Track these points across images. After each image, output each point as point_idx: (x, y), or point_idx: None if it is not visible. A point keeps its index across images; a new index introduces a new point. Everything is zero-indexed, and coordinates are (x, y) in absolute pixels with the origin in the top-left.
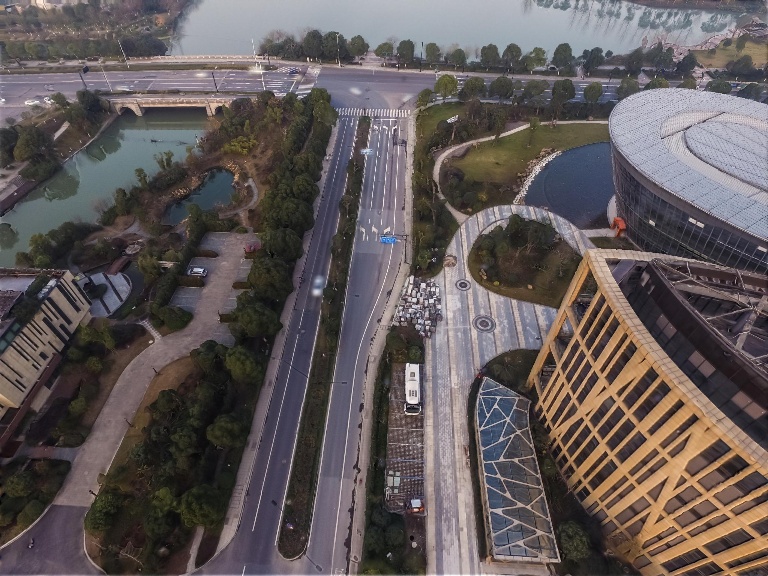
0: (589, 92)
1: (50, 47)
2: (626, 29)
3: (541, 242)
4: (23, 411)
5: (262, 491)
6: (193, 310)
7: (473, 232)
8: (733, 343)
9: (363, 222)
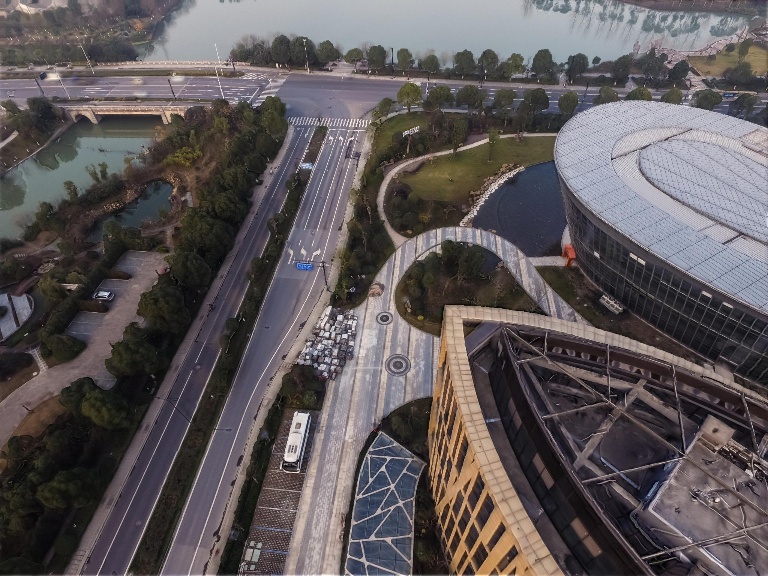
0: (563, 102)
1: (17, 52)
2: (629, 33)
3: (473, 273)
4: None
5: (105, 559)
6: (89, 339)
7: (408, 257)
8: (579, 449)
9: (293, 243)
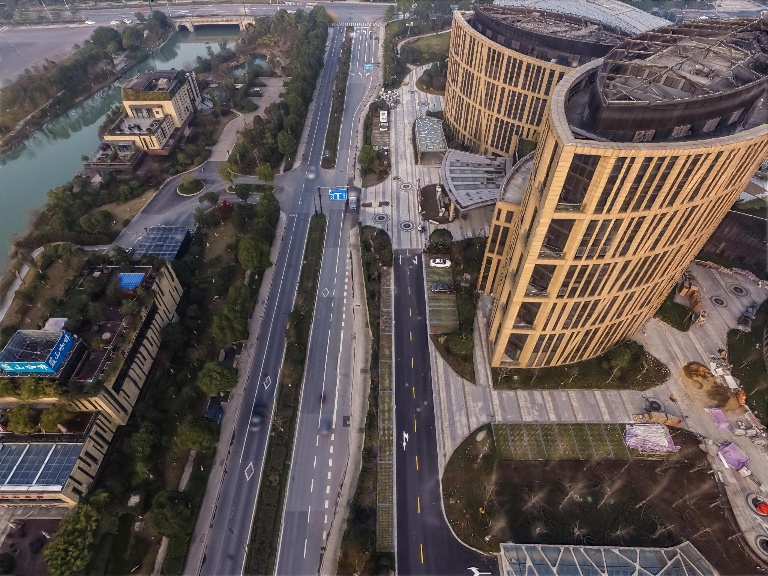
0: None
1: None
2: None
3: None
4: (183, 129)
5: (310, 154)
6: (258, 105)
7: (420, 73)
8: None
9: (353, 71)
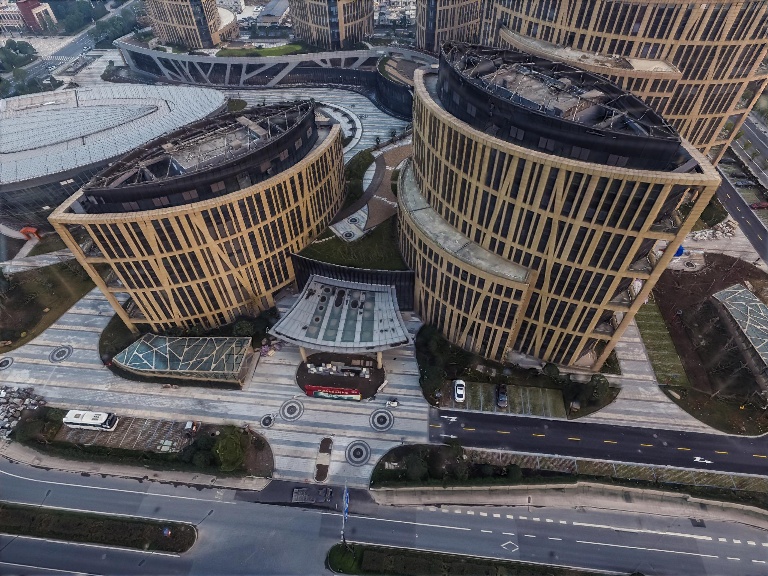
0: None
1: None
2: None
3: (5, 284)
4: None
5: None
6: None
7: None
8: None
9: None
